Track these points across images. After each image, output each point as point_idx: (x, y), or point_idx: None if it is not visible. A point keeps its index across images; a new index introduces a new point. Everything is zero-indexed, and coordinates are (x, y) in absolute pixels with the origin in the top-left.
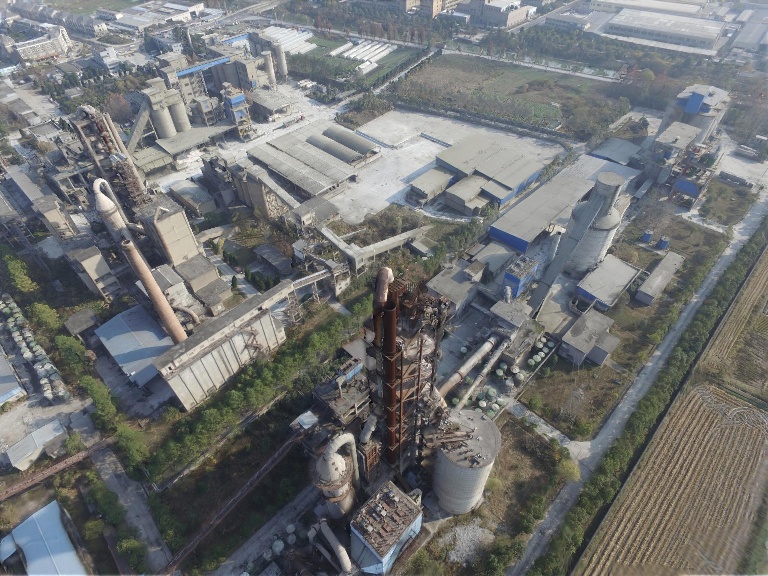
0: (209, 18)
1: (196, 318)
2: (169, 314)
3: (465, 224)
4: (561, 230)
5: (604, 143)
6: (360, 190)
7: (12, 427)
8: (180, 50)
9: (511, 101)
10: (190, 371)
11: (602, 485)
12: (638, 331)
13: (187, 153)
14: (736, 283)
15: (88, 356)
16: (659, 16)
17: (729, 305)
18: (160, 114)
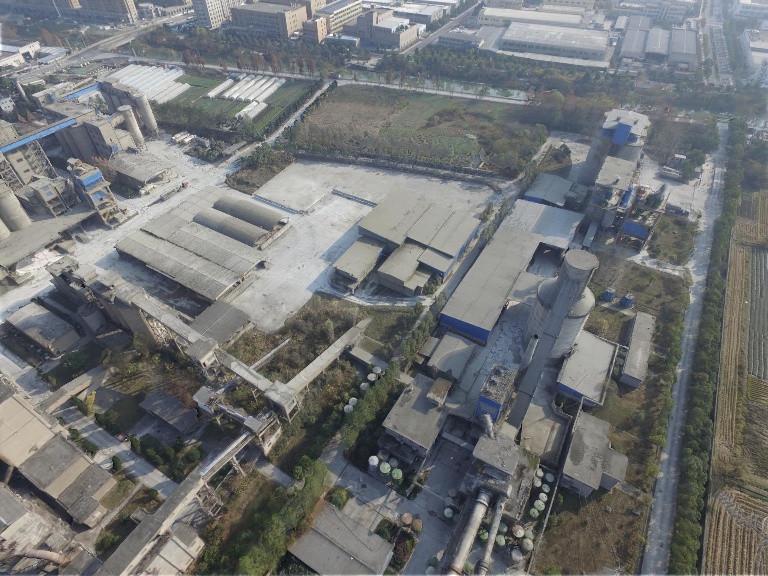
0: (48, 59)
1: (58, 559)
2: None
3: (409, 310)
4: None
5: (534, 181)
6: (272, 279)
7: None
8: (11, 106)
9: (427, 142)
10: None
11: None
12: (635, 428)
13: (31, 256)
14: (716, 343)
15: None
16: (547, 28)
17: (717, 373)
18: None
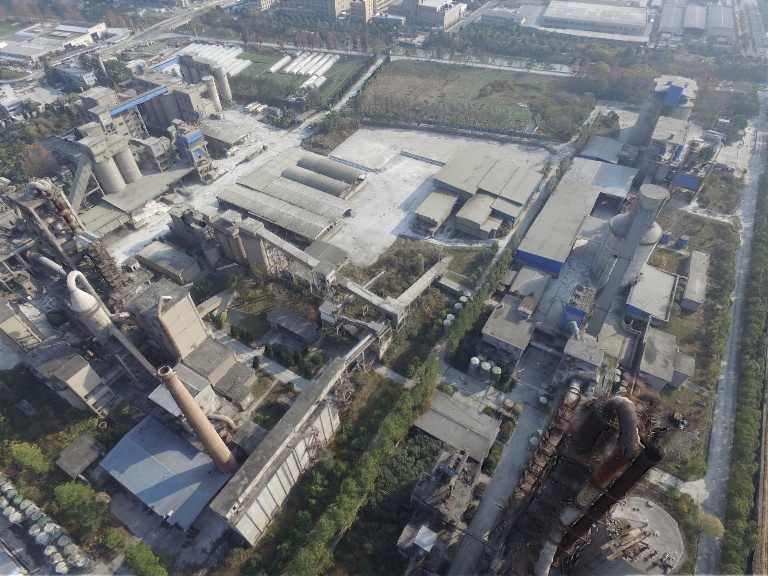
0: (115, 39)
1: (232, 424)
2: (213, 435)
3: (485, 250)
4: (581, 242)
5: (588, 142)
6: (359, 225)
7: None
8: (93, 80)
9: (486, 108)
10: (256, 502)
11: (744, 532)
12: (697, 342)
13: (142, 206)
14: (766, 275)
15: (101, 501)
16: (586, 6)
17: (767, 299)
18: (105, 166)
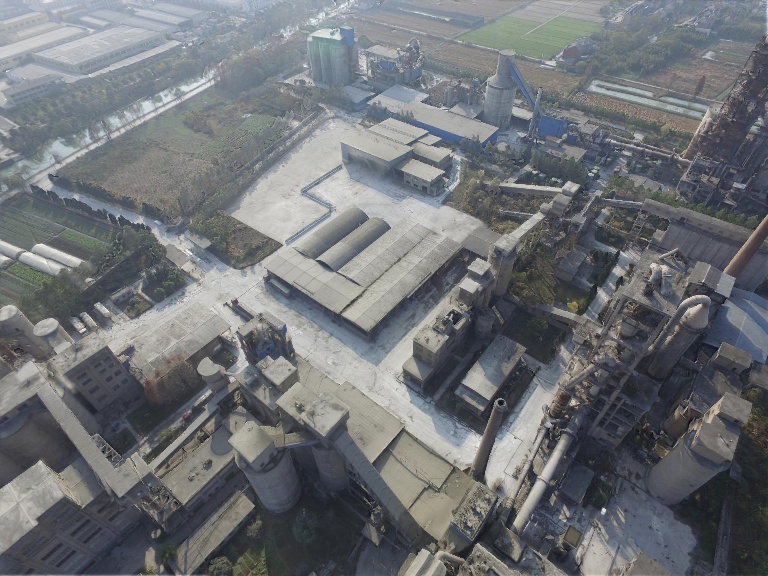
0: None
1: None
2: None
3: None
4: None
5: None
6: None
7: None
8: None
9: None
10: None
11: None
12: None
13: None
14: None
15: None
16: (78, 43)
17: None
18: None
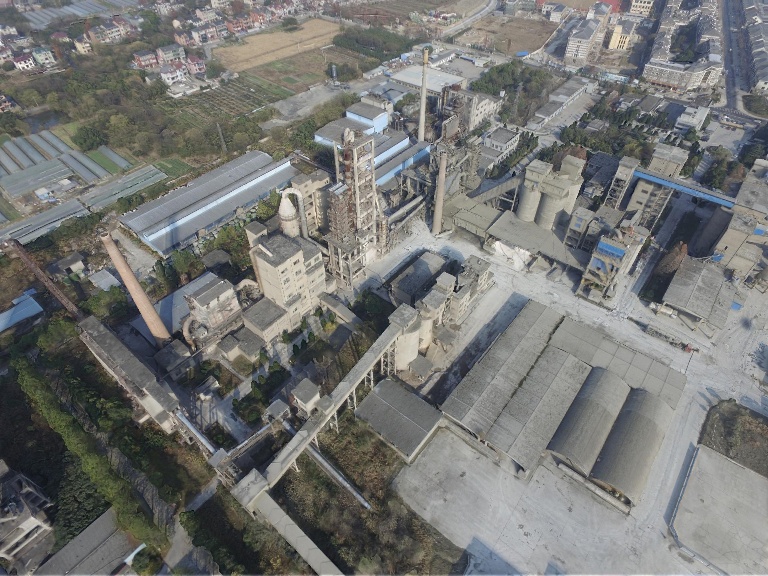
0: None
1: (185, 336)
2: (140, 308)
3: None
4: None
5: None
6: (495, 484)
7: (137, 264)
8: None
9: None
10: None
11: None
12: None
13: None
14: None
15: (181, 278)
16: None
17: None
18: (526, 192)
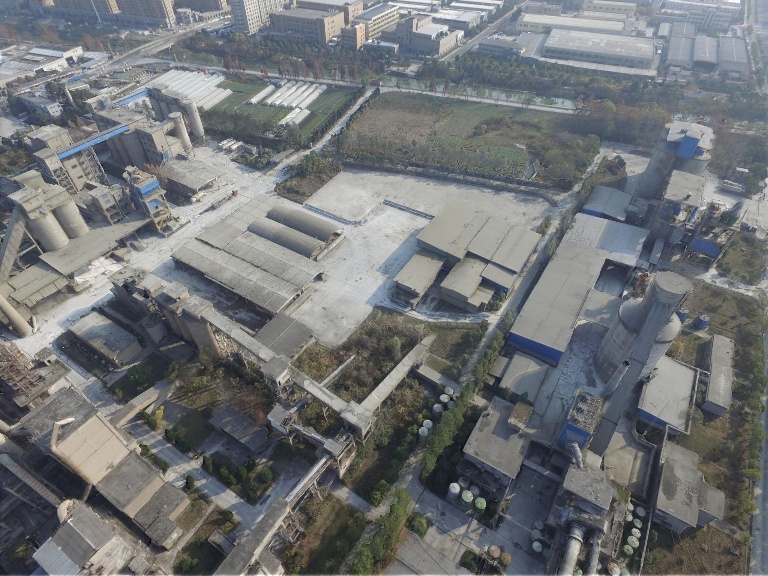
0: (91, 64)
1: None
2: None
3: (474, 328)
4: None
5: (592, 194)
6: (330, 292)
7: None
8: (59, 111)
9: (480, 152)
10: None
11: None
12: (723, 459)
13: (88, 264)
14: None
15: None
16: (590, 35)
17: None
18: (41, 223)
